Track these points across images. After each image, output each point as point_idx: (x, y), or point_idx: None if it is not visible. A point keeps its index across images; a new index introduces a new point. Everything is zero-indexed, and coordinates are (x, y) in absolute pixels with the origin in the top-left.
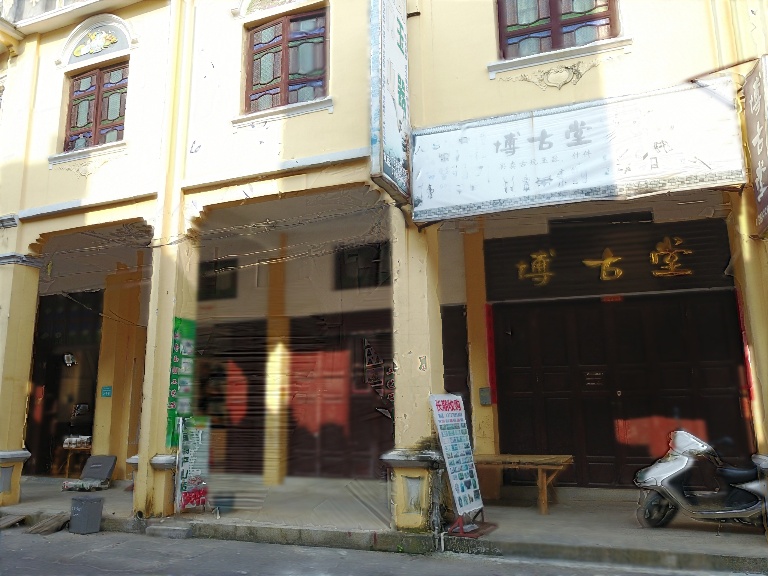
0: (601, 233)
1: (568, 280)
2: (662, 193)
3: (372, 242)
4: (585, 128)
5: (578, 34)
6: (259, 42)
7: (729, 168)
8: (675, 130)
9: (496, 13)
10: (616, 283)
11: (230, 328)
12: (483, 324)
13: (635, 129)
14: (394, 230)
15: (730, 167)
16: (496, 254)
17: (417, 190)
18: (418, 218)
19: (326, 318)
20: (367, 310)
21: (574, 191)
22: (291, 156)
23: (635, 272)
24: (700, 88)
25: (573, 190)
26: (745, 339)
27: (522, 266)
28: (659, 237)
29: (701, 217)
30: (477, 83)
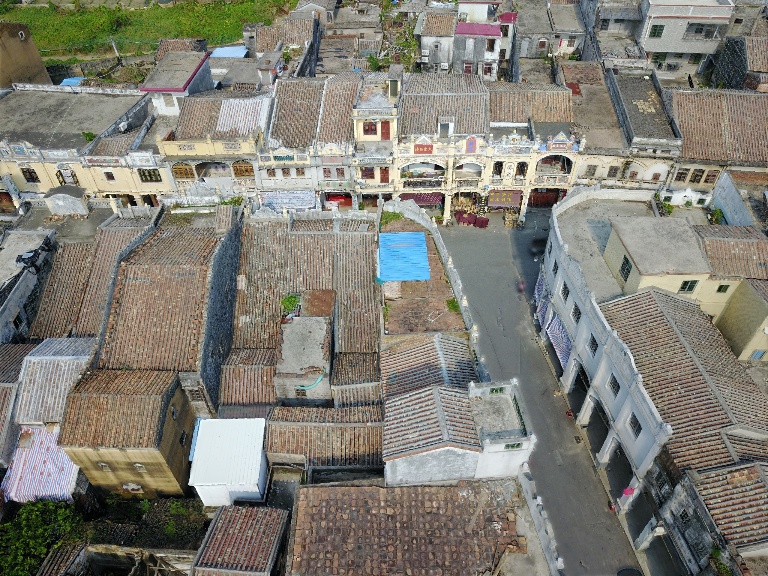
0: None
1: None
2: None
3: None
4: None
5: None
6: None
7: None
8: None
9: None
10: None
11: (5, 206)
12: None
13: None
14: None
15: None
16: None
17: None
18: None
19: None
20: None
21: None
22: None
23: None
24: None
25: None
26: None
27: None
28: None
29: None
30: (25, 184)
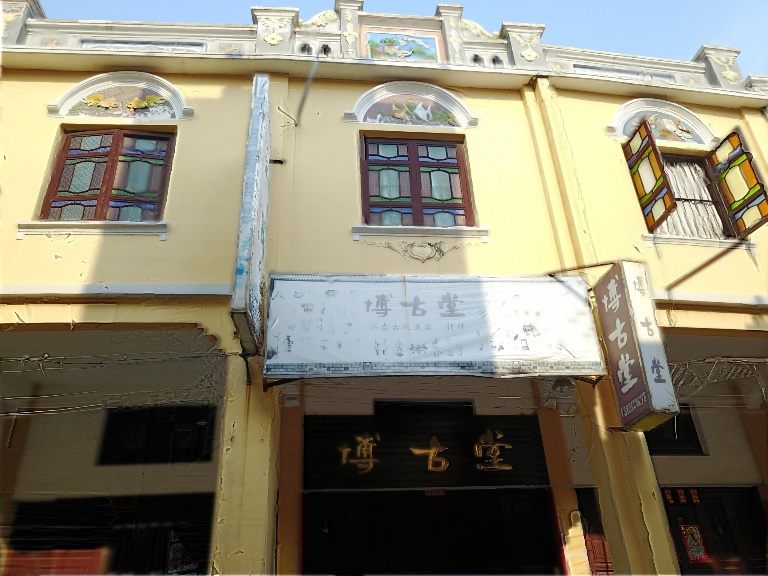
0: (427, 420)
1: (395, 469)
2: (534, 376)
3: (198, 398)
4: (458, 301)
5: (437, 217)
6: (77, 147)
7: (590, 359)
8: (540, 316)
9: (359, 181)
10: (443, 475)
11: None
12: (298, 518)
13: (505, 310)
14: (231, 386)
15: (590, 358)
16: (318, 433)
17: (272, 340)
18: (271, 373)
19: (115, 499)
20: (180, 489)
21: (450, 363)
22: (99, 279)
23: (461, 464)
24: (557, 282)
25: (449, 362)
26: (564, 542)
27: (346, 449)
28: (482, 429)
29: (517, 413)
30: (339, 241)
